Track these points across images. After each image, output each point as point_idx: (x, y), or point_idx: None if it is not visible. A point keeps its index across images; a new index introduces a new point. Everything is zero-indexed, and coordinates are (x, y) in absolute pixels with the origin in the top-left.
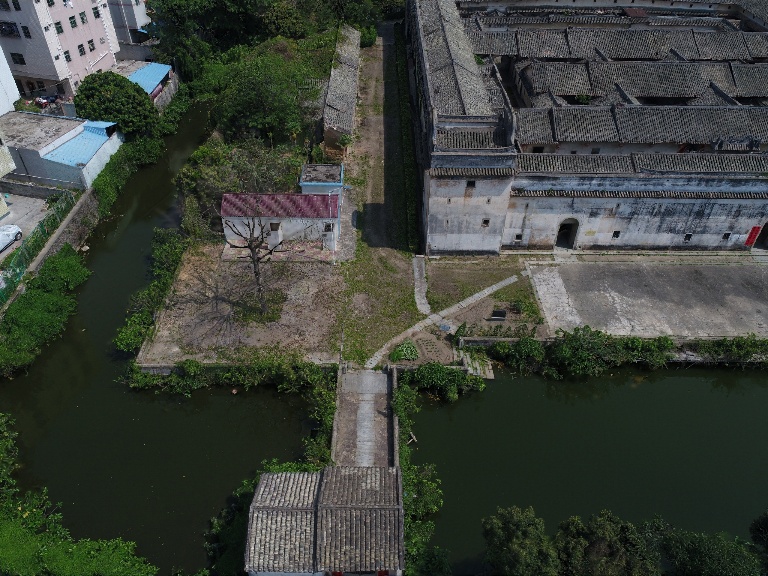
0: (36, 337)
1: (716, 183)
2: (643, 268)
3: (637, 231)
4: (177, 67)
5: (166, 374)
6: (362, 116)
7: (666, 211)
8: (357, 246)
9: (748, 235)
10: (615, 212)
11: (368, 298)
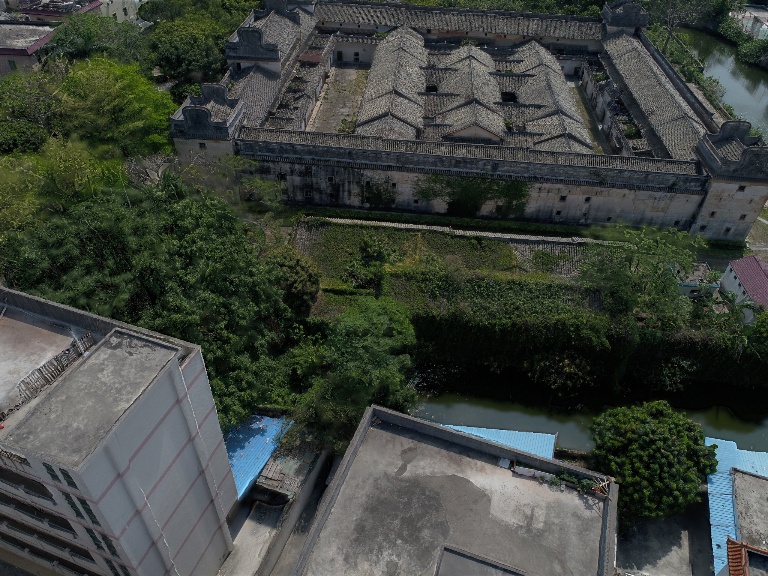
0: None
1: None
2: None
3: None
4: None
5: None
6: None
7: None
8: None
9: None
10: None
11: None
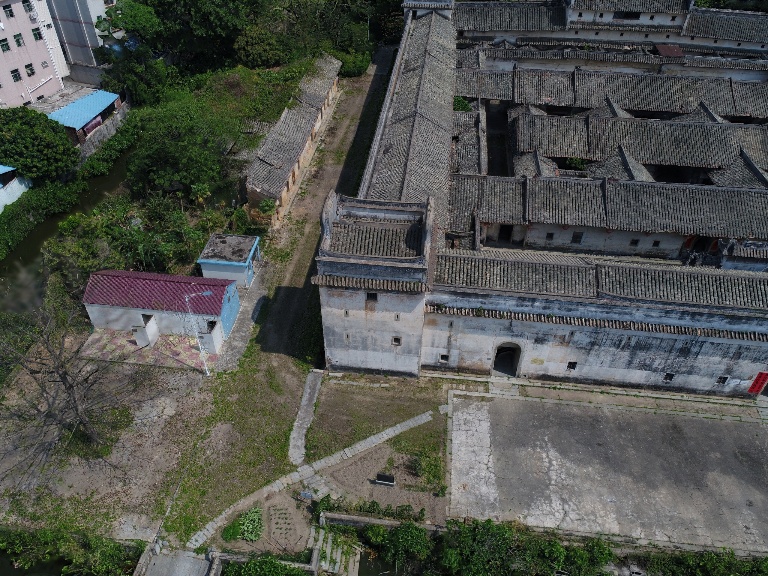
0: None
1: (706, 318)
2: (603, 415)
3: (600, 364)
4: (129, 95)
5: None
6: (318, 165)
7: (638, 345)
8: (246, 349)
9: (752, 381)
10: (568, 340)
11: (231, 431)
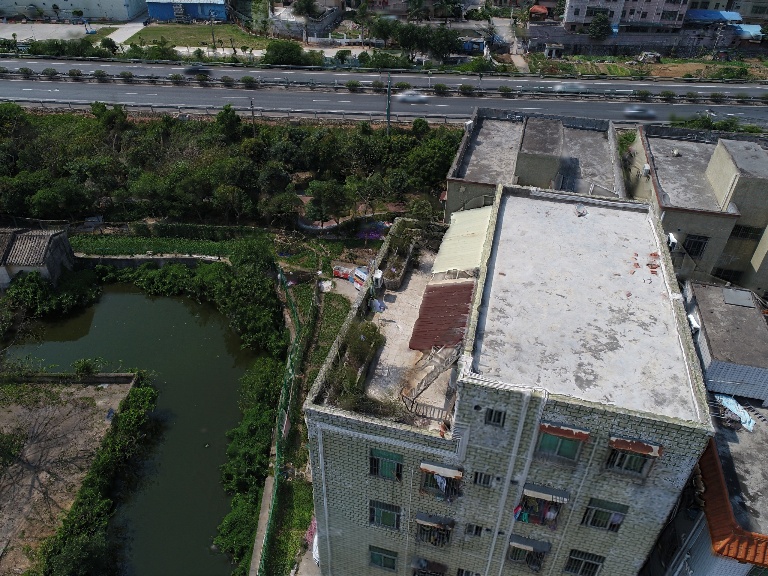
0: None
1: None
2: None
3: None
4: None
5: None
6: None
7: None
8: None
9: None
10: None
11: None
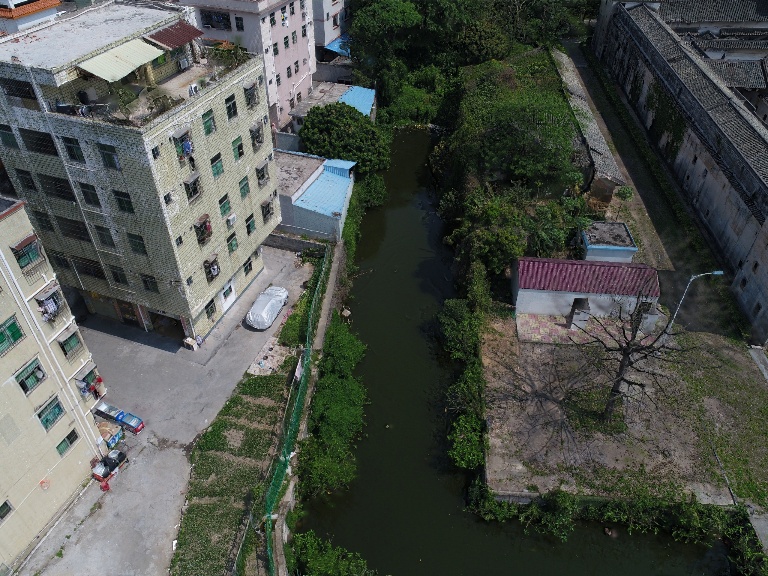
0: (345, 437)
1: None
2: None
3: None
4: (376, 91)
5: (522, 503)
6: None
7: None
8: (673, 329)
9: None
10: None
11: (722, 405)
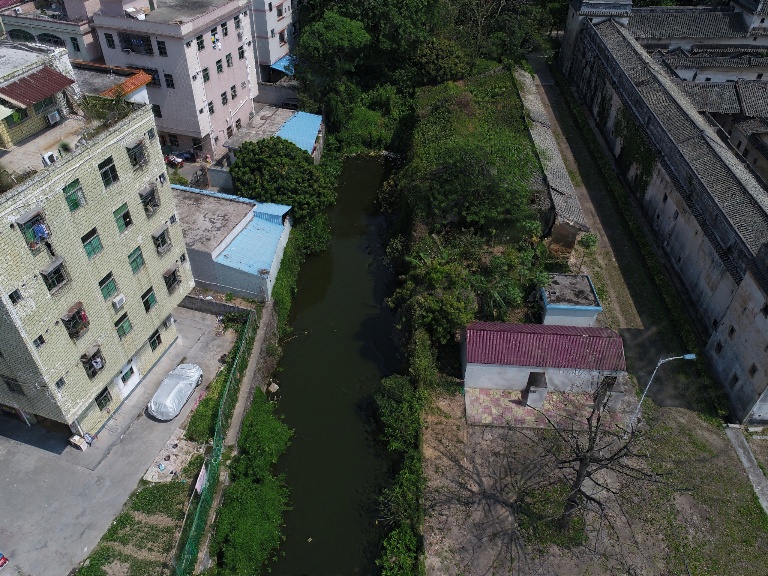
0: (256, 561)
1: None
2: None
3: None
4: (324, 116)
5: None
6: None
7: None
8: (641, 404)
9: None
10: None
11: (696, 504)
